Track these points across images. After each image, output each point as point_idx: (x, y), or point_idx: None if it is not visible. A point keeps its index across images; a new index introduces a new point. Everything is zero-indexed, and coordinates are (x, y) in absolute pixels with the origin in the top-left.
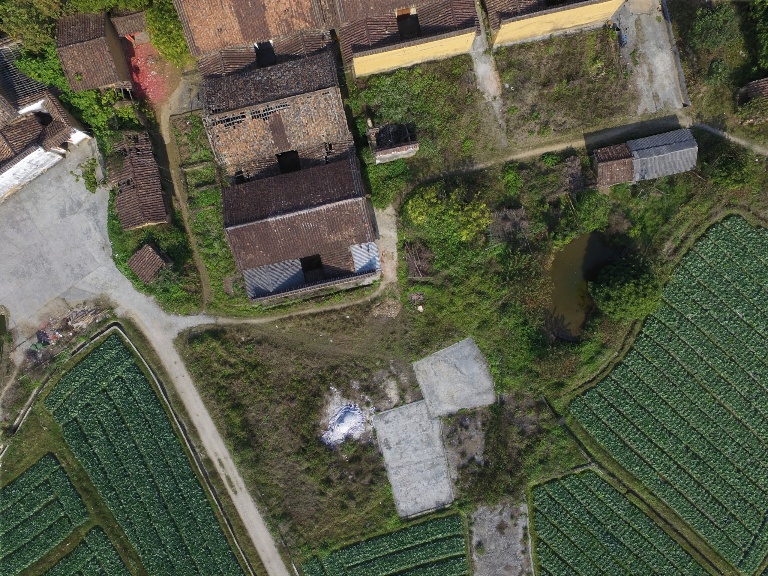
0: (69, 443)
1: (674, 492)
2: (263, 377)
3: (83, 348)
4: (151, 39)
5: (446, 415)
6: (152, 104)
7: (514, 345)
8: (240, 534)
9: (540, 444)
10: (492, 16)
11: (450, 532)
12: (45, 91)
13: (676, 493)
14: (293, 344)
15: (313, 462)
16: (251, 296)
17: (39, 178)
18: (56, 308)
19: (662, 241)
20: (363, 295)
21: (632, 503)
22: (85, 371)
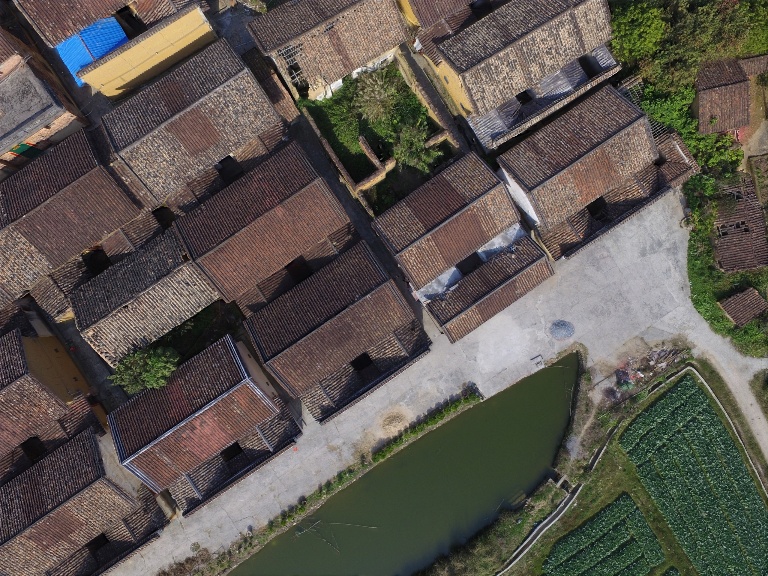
0: (647, 483)
1: None
2: None
3: (659, 388)
4: None
5: None
6: None
7: None
8: None
9: None
10: None
11: None
12: (675, 132)
13: None
14: None
15: None
16: None
17: None
18: (635, 347)
19: None
20: None
21: None
22: (664, 411)
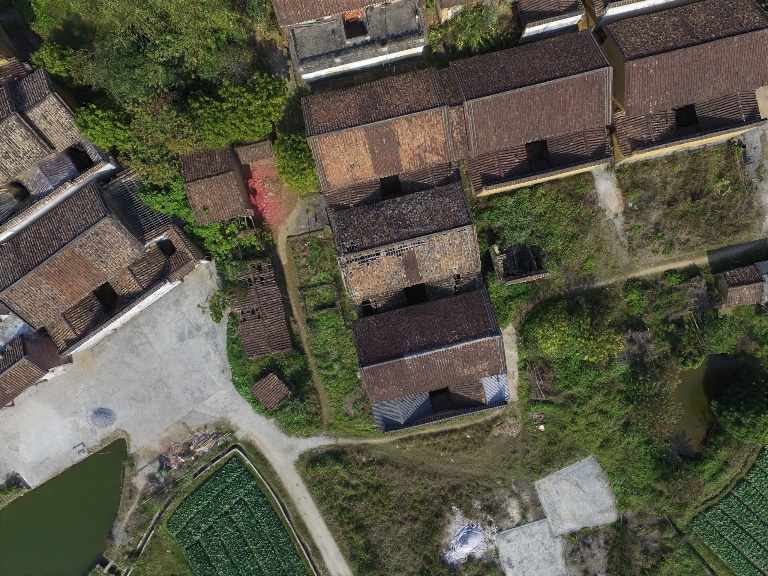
0: (193, 566)
1: None
2: (385, 498)
3: (205, 471)
4: (279, 172)
5: (568, 534)
6: (269, 225)
7: (638, 465)
8: None
9: (665, 564)
10: (623, 142)
11: None
12: (171, 224)
13: None
14: (414, 464)
15: None
16: (379, 425)
17: (157, 302)
18: (177, 432)
19: None
20: (484, 414)
21: None
22: (208, 495)
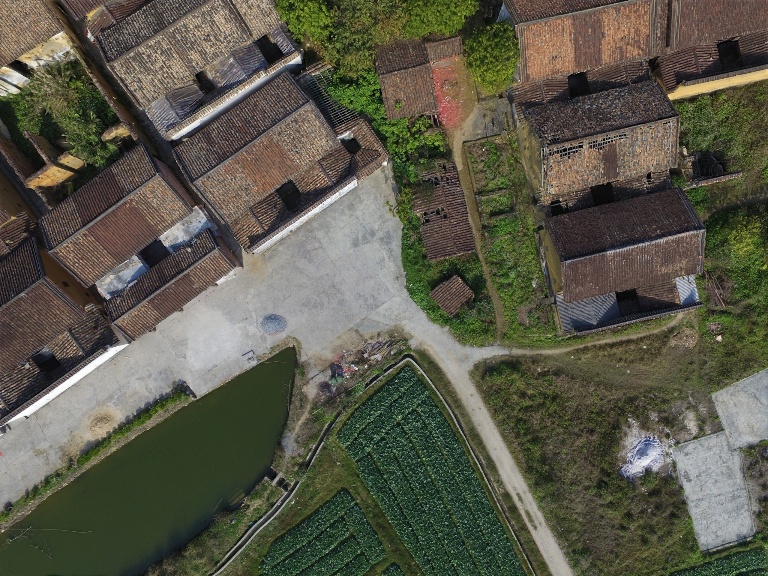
0: (365, 479)
1: None
2: (561, 409)
3: (377, 381)
4: (476, 66)
5: (746, 446)
6: (446, 130)
7: None
8: (542, 570)
9: None
10: None
11: (754, 566)
12: (362, 119)
13: None
14: (589, 375)
15: (616, 496)
16: (567, 328)
17: (331, 206)
18: (349, 340)
19: None
20: (660, 325)
21: None
22: (381, 404)
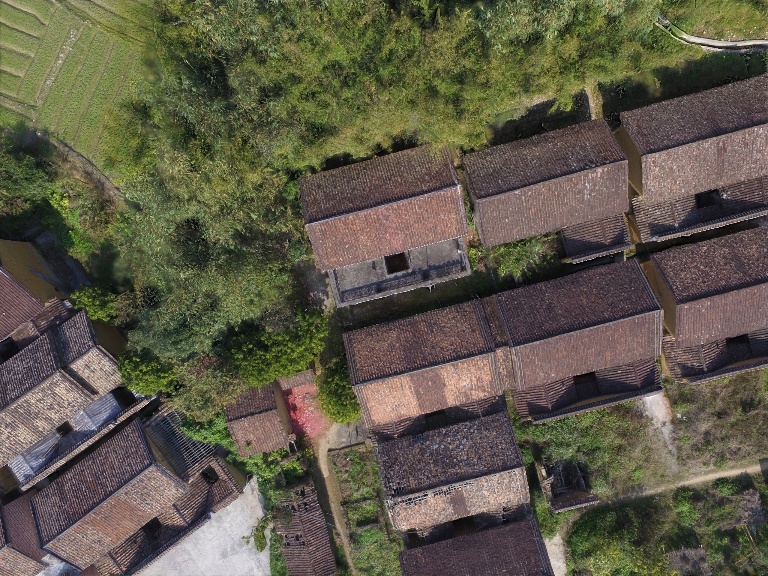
0: None
1: None
2: None
3: None
4: (323, 408)
5: None
6: (310, 439)
7: None
8: None
9: None
10: (673, 366)
11: None
12: (214, 458)
13: None
14: None
15: None
16: None
17: None
18: None
19: None
20: None
21: None
22: None
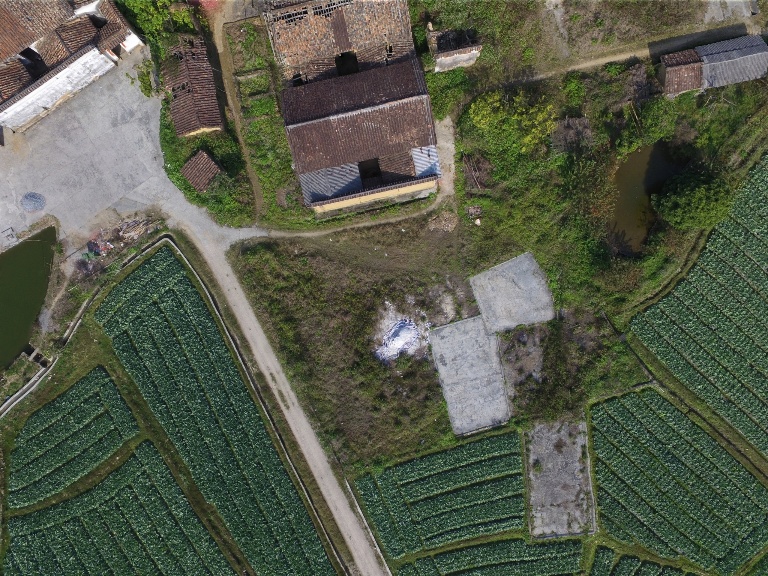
0: (120, 355)
1: (738, 411)
2: (317, 290)
3: (134, 260)
4: None
5: (503, 331)
6: (205, 11)
7: (574, 259)
8: (292, 449)
9: (601, 360)
10: None
11: (507, 450)
12: None
13: (740, 412)
14: (347, 258)
15: (368, 376)
16: (308, 202)
17: (91, 86)
18: (107, 218)
19: (728, 154)
20: (419, 208)
21: (694, 423)
22: (136, 282)
